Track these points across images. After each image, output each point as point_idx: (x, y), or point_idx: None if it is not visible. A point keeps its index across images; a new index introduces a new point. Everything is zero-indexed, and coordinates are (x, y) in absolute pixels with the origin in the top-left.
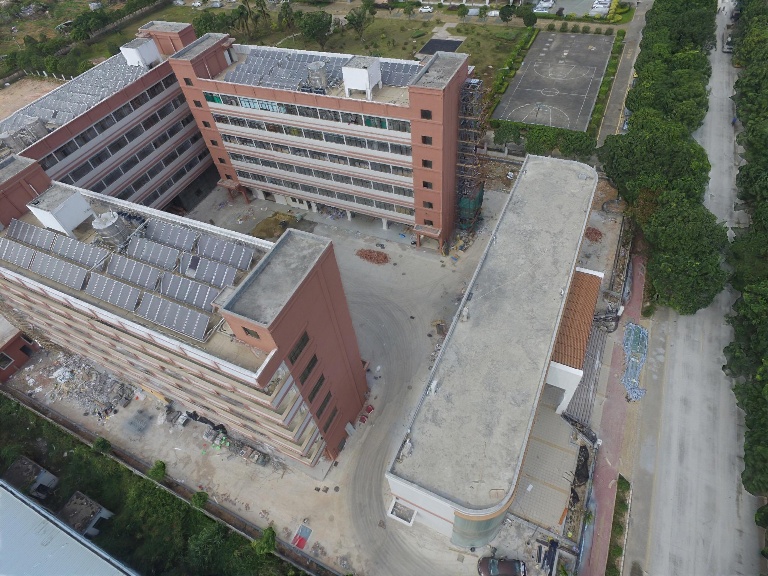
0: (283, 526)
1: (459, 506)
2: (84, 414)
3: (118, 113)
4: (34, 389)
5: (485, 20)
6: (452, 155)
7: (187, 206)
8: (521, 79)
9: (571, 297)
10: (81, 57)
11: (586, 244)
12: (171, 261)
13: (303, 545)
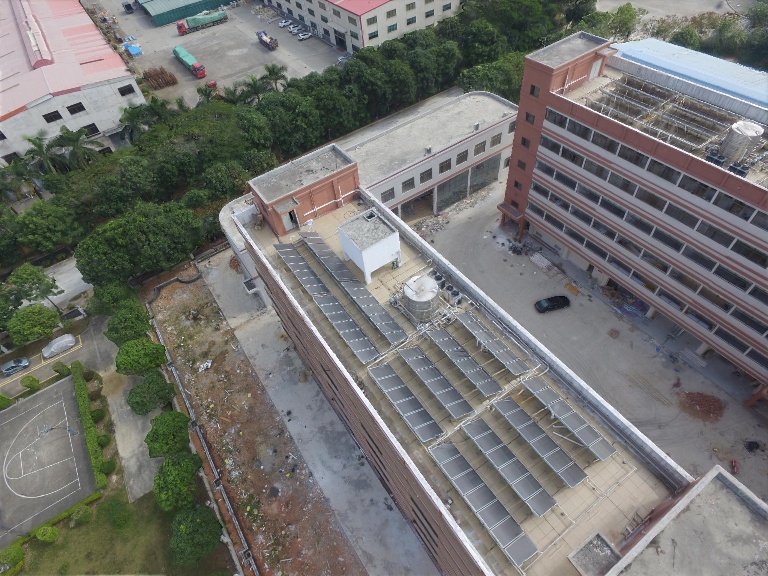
0: None
1: (494, 94)
2: None
3: None
4: None
5: None
6: None
7: None
8: None
9: None
10: None
11: None
12: None
13: None
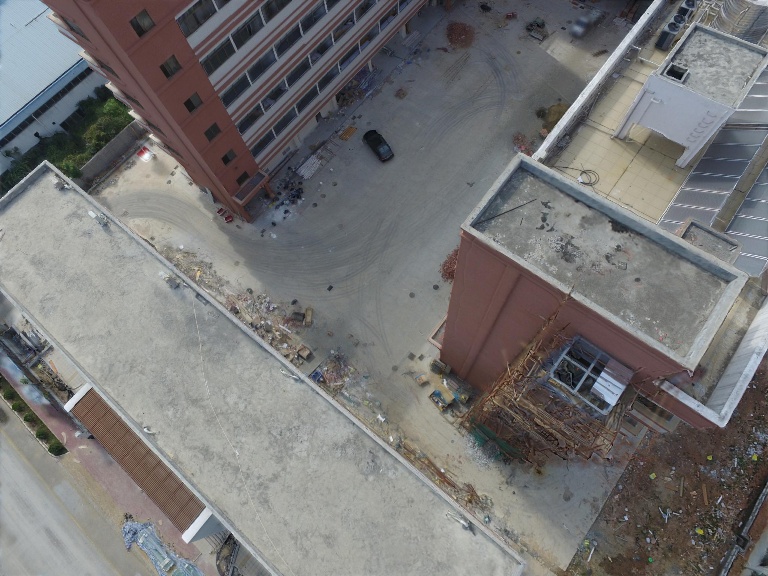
0: None
1: None
2: None
3: None
4: None
5: None
6: None
7: None
8: None
9: None
10: None
11: None
12: None
13: (139, 154)
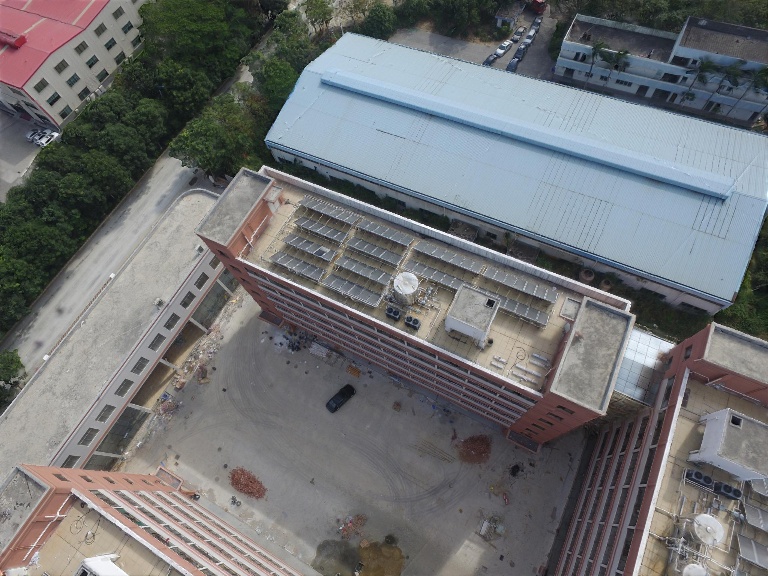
0: None
1: (206, 191)
2: None
3: None
4: None
5: None
6: None
7: None
8: None
9: None
10: None
11: None
12: (344, 260)
13: None
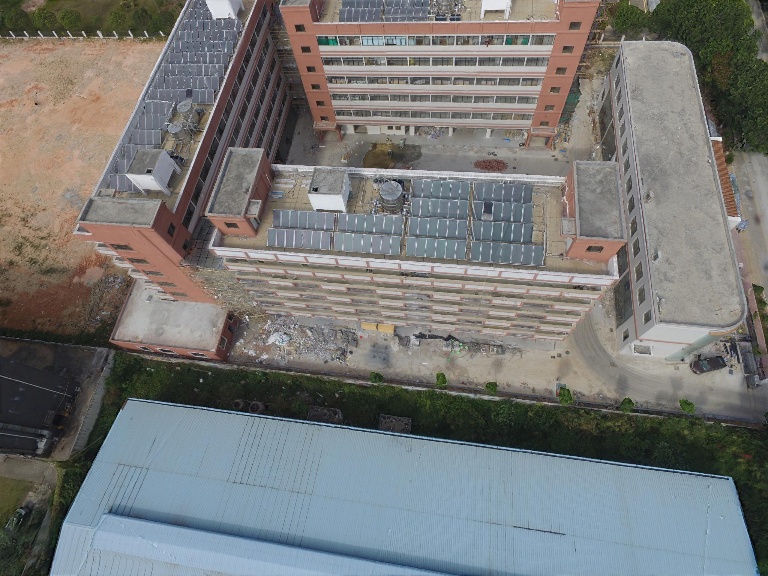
0: (543, 388)
1: (718, 328)
2: (325, 362)
3: (238, 77)
4: (260, 357)
5: None
6: None
7: (283, 157)
8: None
9: None
10: (9, 2)
11: None
12: (463, 211)
13: None
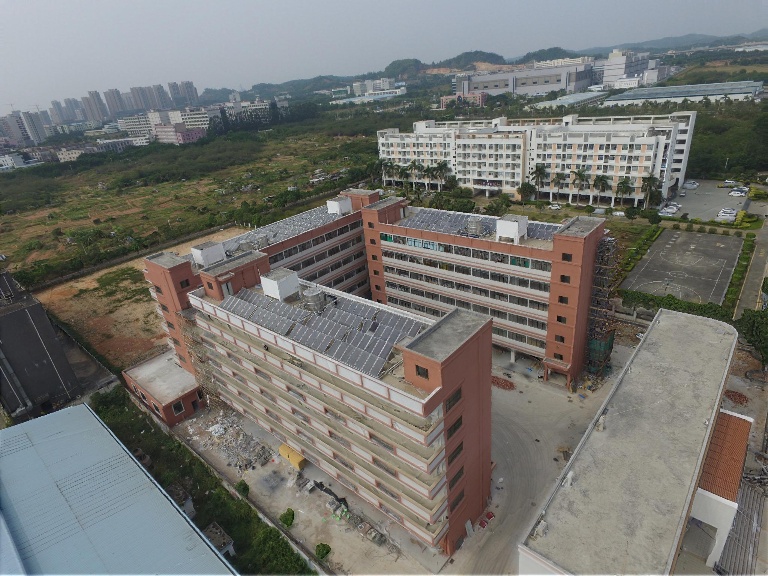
0: None
1: None
2: (228, 464)
3: (315, 241)
4: (192, 437)
5: (610, 217)
6: (586, 297)
7: None
8: (648, 262)
9: (717, 434)
10: (276, 218)
11: (729, 405)
12: (355, 325)
13: None
